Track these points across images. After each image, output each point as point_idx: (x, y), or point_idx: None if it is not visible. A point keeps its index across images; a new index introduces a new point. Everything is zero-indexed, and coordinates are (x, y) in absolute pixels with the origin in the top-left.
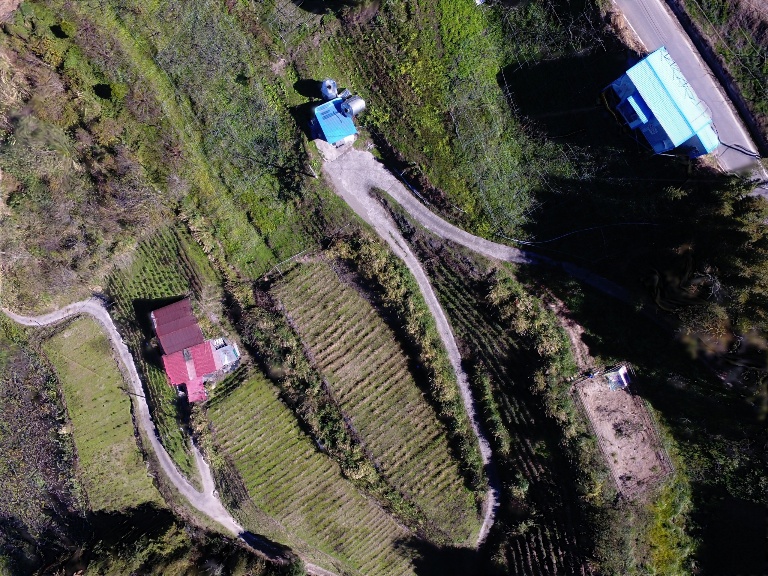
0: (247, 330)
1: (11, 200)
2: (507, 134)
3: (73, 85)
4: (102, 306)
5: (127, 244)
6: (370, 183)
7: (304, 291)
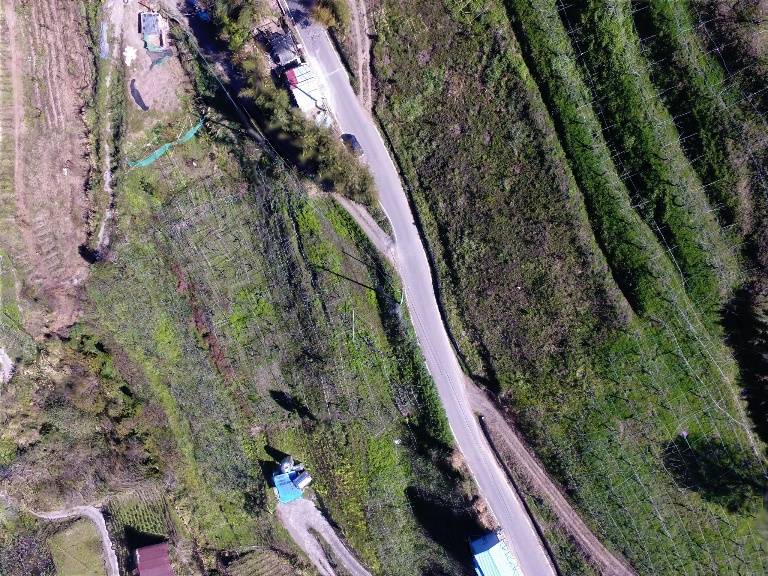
0: (209, 572)
1: (43, 429)
2: (408, 526)
3: (105, 388)
4: (100, 512)
5: (127, 491)
6: (309, 524)
7: (253, 572)
